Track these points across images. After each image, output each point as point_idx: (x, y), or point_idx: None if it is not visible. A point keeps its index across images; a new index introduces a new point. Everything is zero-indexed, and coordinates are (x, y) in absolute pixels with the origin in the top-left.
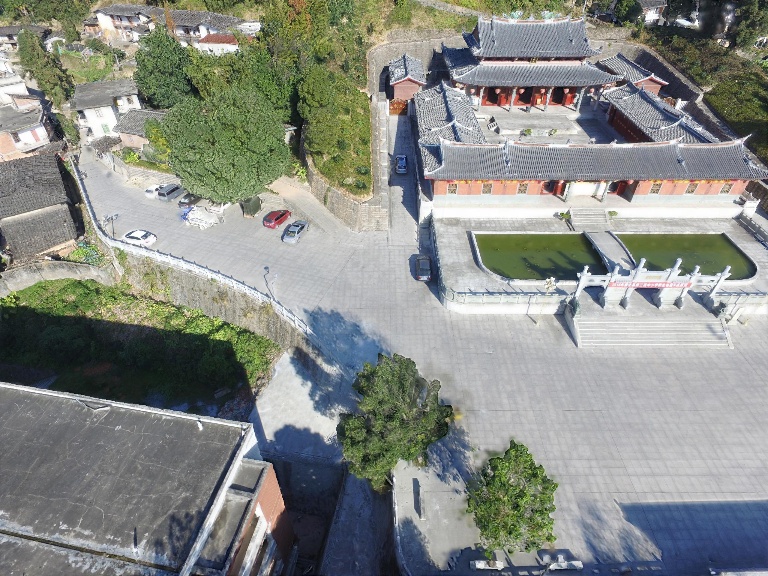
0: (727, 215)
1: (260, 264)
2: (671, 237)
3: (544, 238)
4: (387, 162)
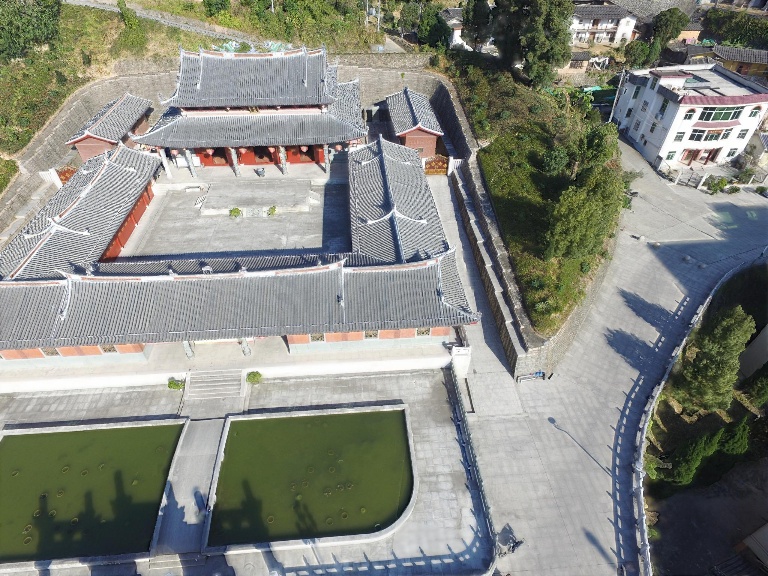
0: (433, 365)
1: None
2: (322, 422)
3: (118, 437)
4: None
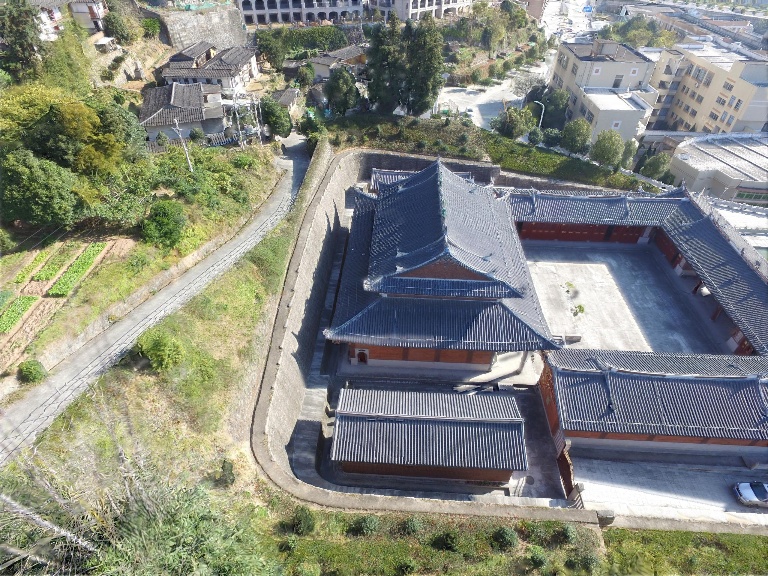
0: None
1: None
2: None
3: None
4: None
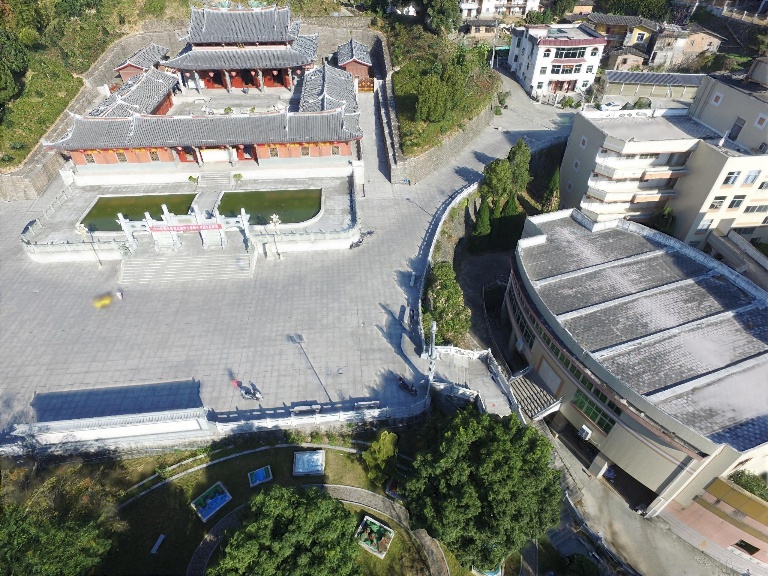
0: (343, 174)
1: None
2: (275, 193)
3: (162, 198)
4: None
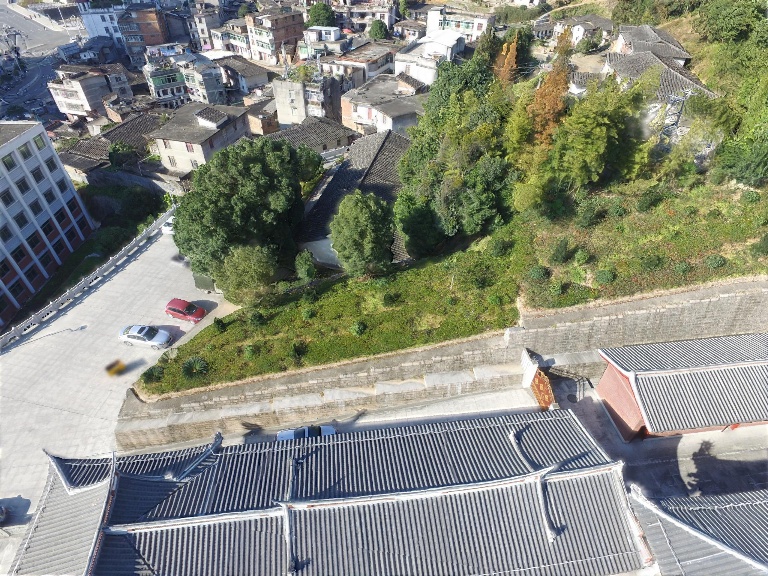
0: None
1: (95, 320)
2: None
3: None
4: (295, 411)
